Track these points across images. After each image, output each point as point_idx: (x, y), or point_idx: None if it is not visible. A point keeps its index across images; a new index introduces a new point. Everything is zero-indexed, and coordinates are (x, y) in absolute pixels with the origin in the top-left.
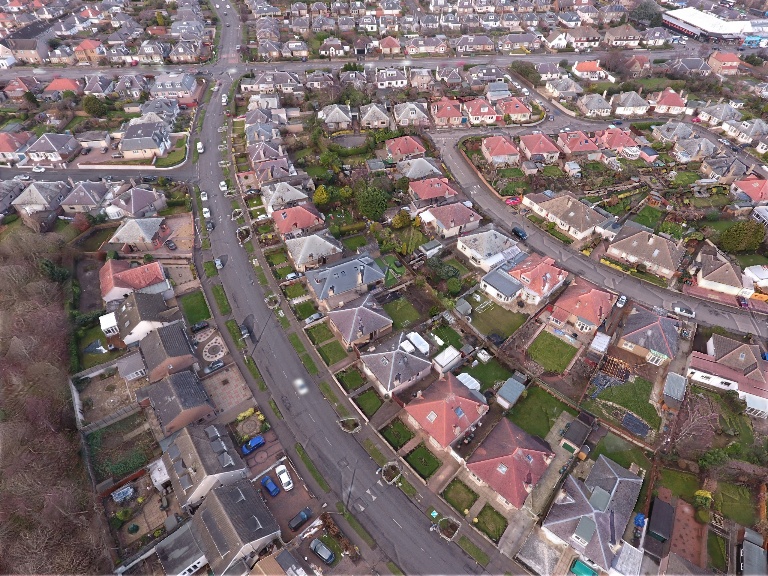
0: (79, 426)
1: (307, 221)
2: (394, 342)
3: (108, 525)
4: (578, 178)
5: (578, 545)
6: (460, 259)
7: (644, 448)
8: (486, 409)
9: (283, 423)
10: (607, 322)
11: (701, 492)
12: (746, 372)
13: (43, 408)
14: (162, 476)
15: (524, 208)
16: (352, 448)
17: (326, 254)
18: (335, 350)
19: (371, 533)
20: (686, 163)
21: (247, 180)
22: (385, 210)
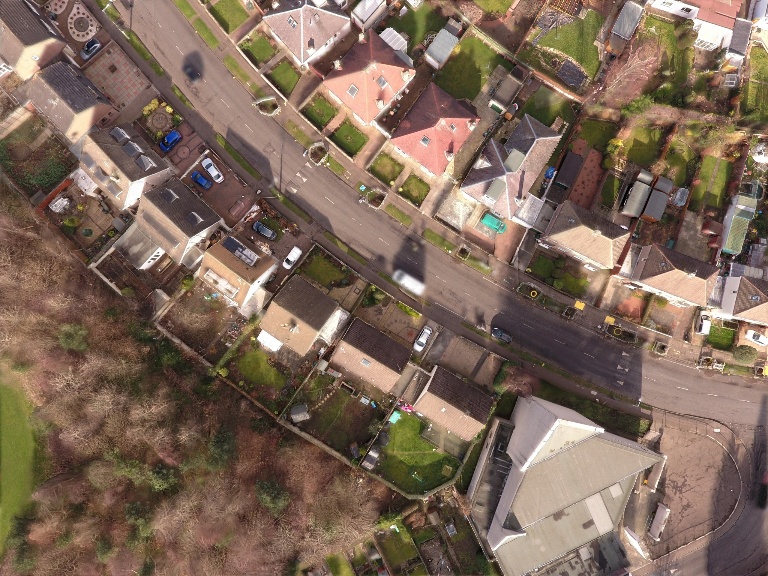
0: None
1: None
2: None
3: (62, 232)
4: None
5: (488, 202)
6: None
7: (573, 100)
8: (412, 74)
9: (195, 113)
10: None
11: (614, 141)
12: None
13: None
14: (89, 184)
15: None
16: (275, 132)
17: None
18: (232, 9)
19: (306, 211)
20: None
21: None
22: None
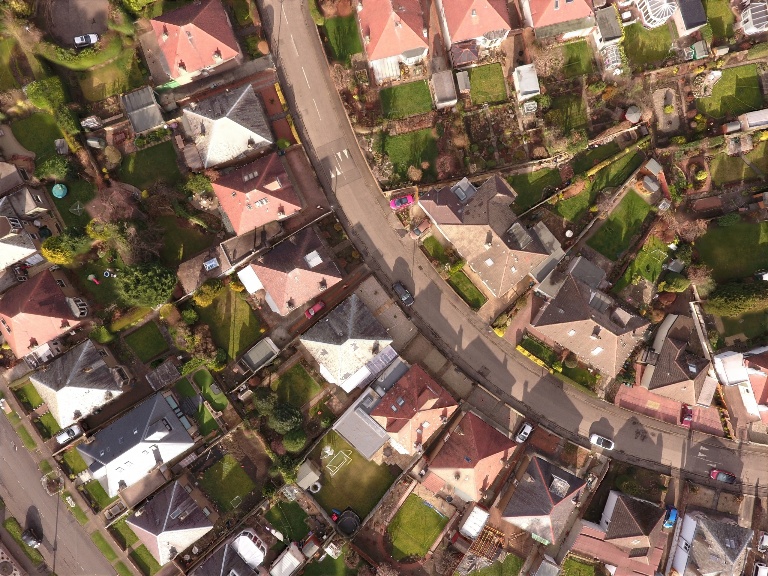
0: None
1: (49, 330)
2: (215, 573)
3: None
4: (531, 113)
5: None
6: (308, 365)
7: None
8: None
9: None
10: None
11: None
12: (632, 554)
13: None
14: None
15: None
16: None
17: (99, 404)
18: None
19: None
20: (751, 41)
21: None
22: None
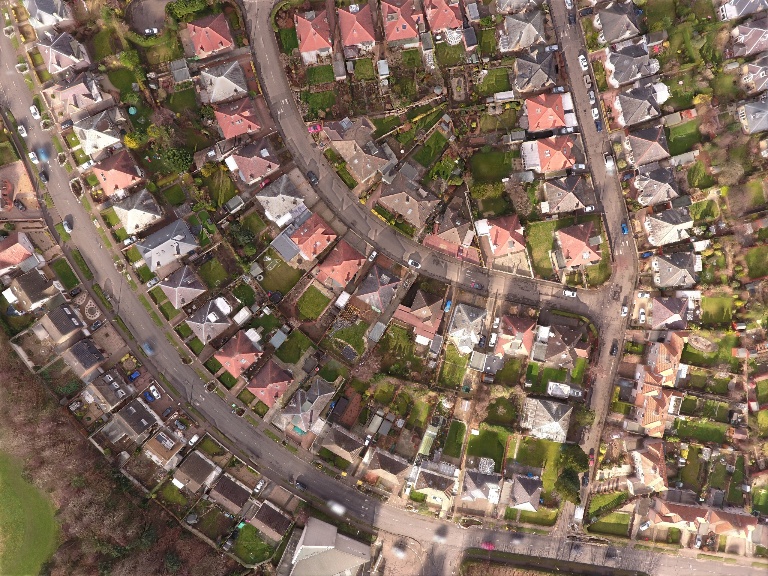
0: (33, 373)
1: (125, 181)
2: (204, 312)
3: (75, 419)
4: (385, 86)
5: None
6: (260, 212)
7: None
8: (260, 355)
9: (149, 361)
10: (357, 275)
11: (366, 392)
12: (424, 321)
13: (5, 356)
14: (91, 399)
15: (323, 140)
16: (190, 373)
17: (149, 222)
18: (171, 308)
19: (203, 415)
20: (503, 55)
21: (55, 100)
22: (193, 159)
